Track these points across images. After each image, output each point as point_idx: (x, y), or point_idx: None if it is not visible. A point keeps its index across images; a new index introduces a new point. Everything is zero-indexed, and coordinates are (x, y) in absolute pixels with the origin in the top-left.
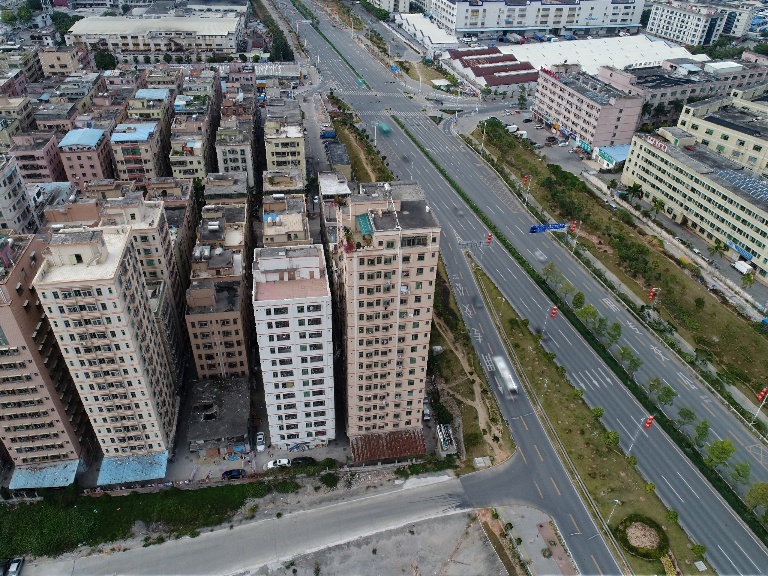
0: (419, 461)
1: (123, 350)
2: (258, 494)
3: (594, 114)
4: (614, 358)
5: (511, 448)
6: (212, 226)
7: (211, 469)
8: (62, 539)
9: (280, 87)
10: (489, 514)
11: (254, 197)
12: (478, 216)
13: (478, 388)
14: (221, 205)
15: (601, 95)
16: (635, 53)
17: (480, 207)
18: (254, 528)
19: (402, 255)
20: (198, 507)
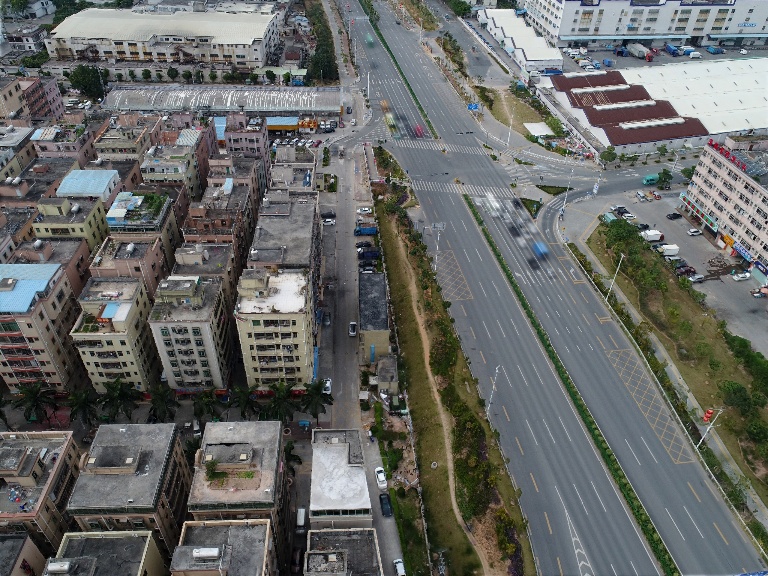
0: None
1: None
2: None
3: None
4: None
5: None
6: None
7: None
8: None
9: (298, 157)
10: None
11: (214, 407)
12: (611, 473)
13: None
14: (99, 532)
15: None
16: None
17: (612, 443)
18: None
19: None
20: None
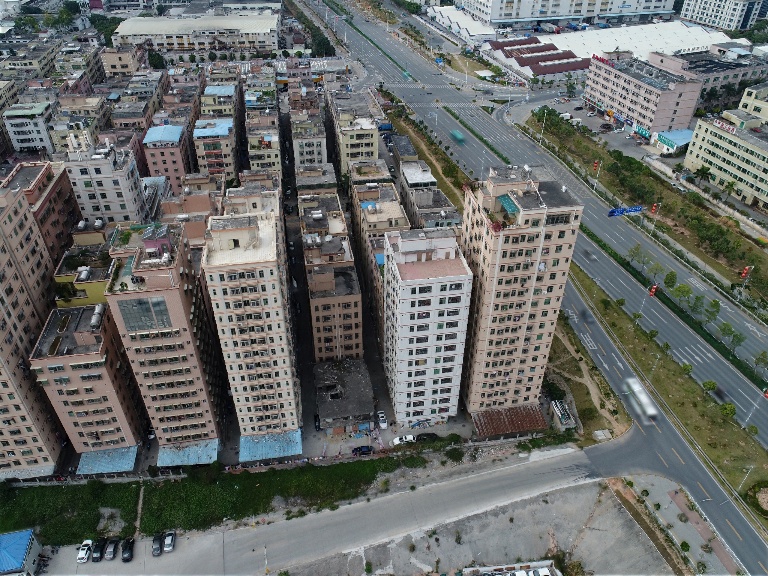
0: (539, 435)
1: (274, 330)
2: (389, 469)
3: (653, 99)
4: (711, 335)
5: (628, 421)
6: (316, 215)
7: (341, 446)
8: (208, 514)
9: None
10: (619, 483)
11: None
12: None
13: (584, 365)
14: (313, 195)
15: (659, 80)
16: (674, 39)
17: None
18: (391, 500)
19: (545, 233)
20: (332, 482)
